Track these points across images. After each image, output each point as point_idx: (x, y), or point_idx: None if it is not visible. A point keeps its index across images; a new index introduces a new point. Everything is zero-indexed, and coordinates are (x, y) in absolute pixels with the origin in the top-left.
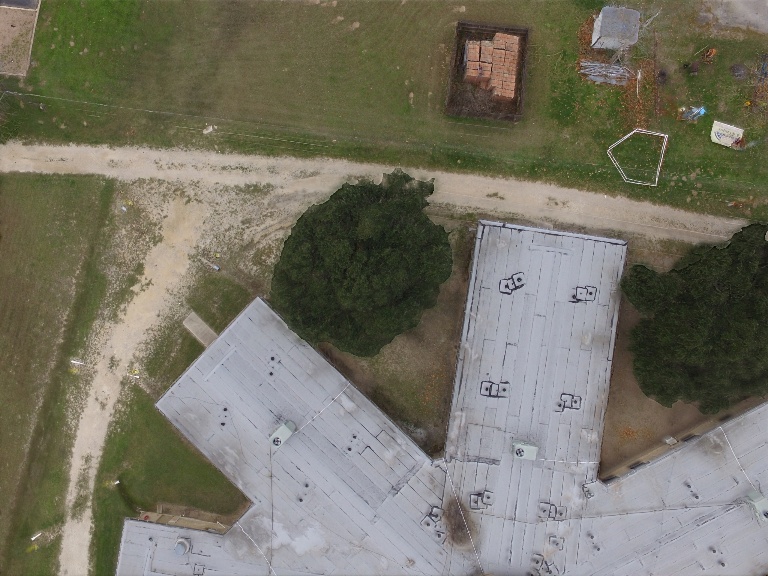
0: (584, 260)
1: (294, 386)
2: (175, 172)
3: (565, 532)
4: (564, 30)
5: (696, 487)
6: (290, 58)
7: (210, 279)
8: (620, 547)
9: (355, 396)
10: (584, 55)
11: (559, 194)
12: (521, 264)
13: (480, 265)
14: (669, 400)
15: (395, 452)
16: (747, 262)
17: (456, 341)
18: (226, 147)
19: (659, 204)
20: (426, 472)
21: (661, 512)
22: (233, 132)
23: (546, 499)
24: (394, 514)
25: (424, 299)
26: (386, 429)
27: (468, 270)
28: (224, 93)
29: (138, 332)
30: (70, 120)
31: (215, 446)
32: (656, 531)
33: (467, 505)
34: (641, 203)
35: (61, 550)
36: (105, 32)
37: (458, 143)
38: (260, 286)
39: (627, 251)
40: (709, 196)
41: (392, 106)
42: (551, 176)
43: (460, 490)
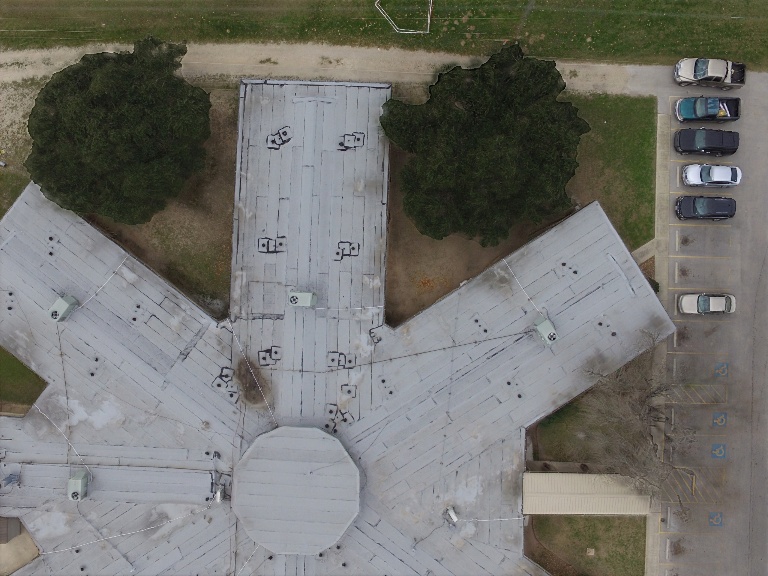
0: (349, 107)
1: (75, 264)
2: None
3: (356, 379)
4: None
5: (484, 321)
6: None
7: None
8: (413, 388)
9: (136, 267)
10: None
11: (332, 52)
12: (286, 118)
13: (246, 124)
14: (436, 231)
15: (180, 318)
16: (483, 74)
17: None
18: (0, 45)
19: (434, 51)
20: (212, 334)
21: (451, 350)
22: (5, 29)
23: (334, 348)
24: None
25: (181, 157)
26: (169, 296)
27: None
28: None
29: None
30: None
31: (5, 331)
32: (447, 369)
33: (256, 362)
34: (416, 52)
35: None
36: None
37: (226, 13)
38: None
39: (392, 94)
40: (484, 37)
41: None
42: (322, 35)
43: (247, 348)
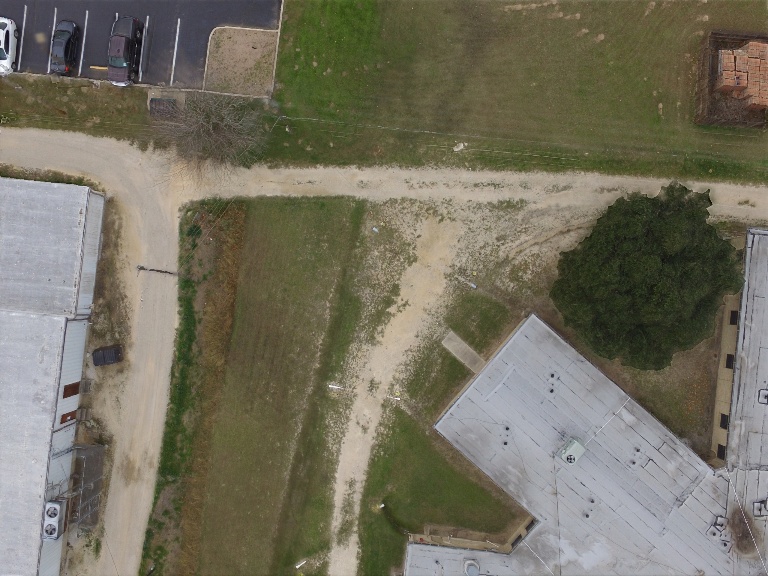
0: None
1: (574, 402)
2: (426, 191)
3: None
4: None
5: None
6: (537, 72)
7: (467, 297)
8: None
9: (635, 410)
10: None
11: None
12: None
13: (752, 274)
14: None
15: (677, 464)
16: None
17: (715, 350)
18: (477, 164)
19: None
20: (709, 482)
21: None
22: (484, 149)
23: None
24: (681, 525)
25: (714, 311)
26: (668, 441)
27: None
28: (472, 109)
29: (397, 354)
30: (316, 142)
31: (498, 466)
32: None
33: (750, 513)
34: None
35: None
36: (347, 51)
37: (709, 152)
38: (518, 303)
39: None
40: None
41: (642, 118)
42: None
43: (743, 498)
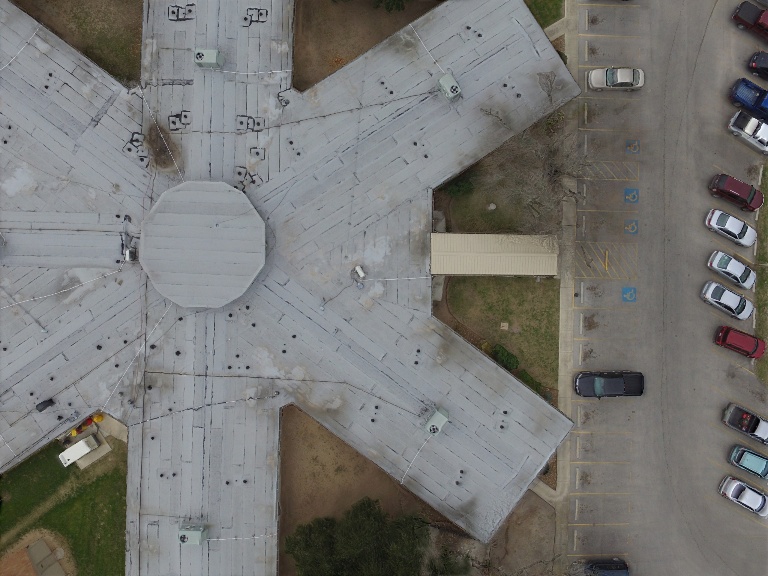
0: None
1: None
2: None
3: (265, 142)
4: None
5: (391, 84)
6: None
7: None
8: (320, 150)
9: (48, 37)
10: None
11: None
12: None
13: None
14: None
15: (92, 85)
16: None
17: None
18: None
19: None
20: (123, 101)
21: (358, 112)
22: None
23: (243, 112)
24: (95, 143)
25: None
26: (81, 64)
27: None
28: None
29: None
30: None
31: None
32: (354, 130)
33: (167, 128)
34: None
35: None
36: None
37: None
38: None
39: None
40: None
41: None
42: None
43: (158, 113)
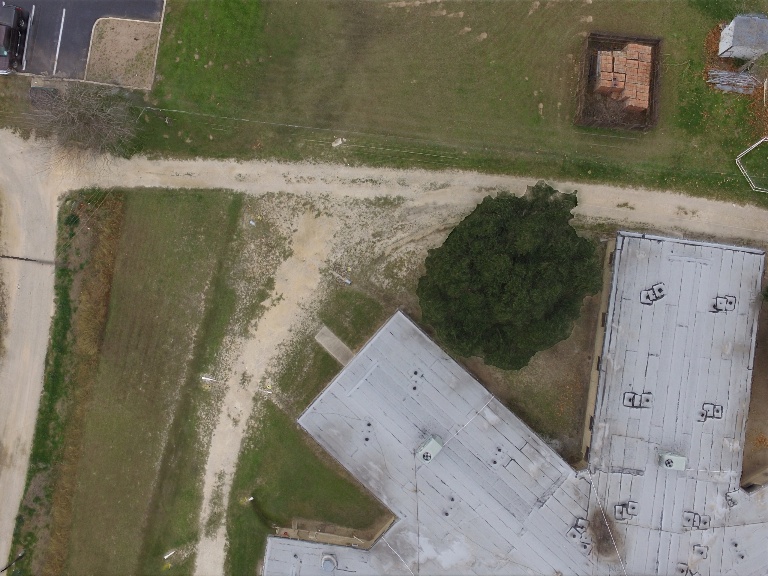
0: (723, 270)
1: (437, 400)
2: (304, 186)
3: (709, 541)
4: (690, 39)
5: None
6: (418, 70)
7: (342, 293)
8: (763, 554)
9: (498, 409)
10: (711, 64)
11: (688, 203)
12: (661, 275)
13: (621, 276)
14: None
15: (539, 464)
16: None
17: (589, 352)
18: (355, 160)
19: None
20: (571, 484)
21: None
22: (363, 145)
23: (690, 508)
24: (540, 526)
25: (573, 312)
26: (530, 441)
27: None
28: (352, 105)
29: (270, 347)
30: (196, 134)
31: (359, 461)
32: None
33: (612, 516)
34: None
35: (195, 568)
36: (229, 44)
37: (588, 154)
38: (392, 299)
39: None
40: None
41: (522, 117)
42: (680, 186)
43: (605, 501)
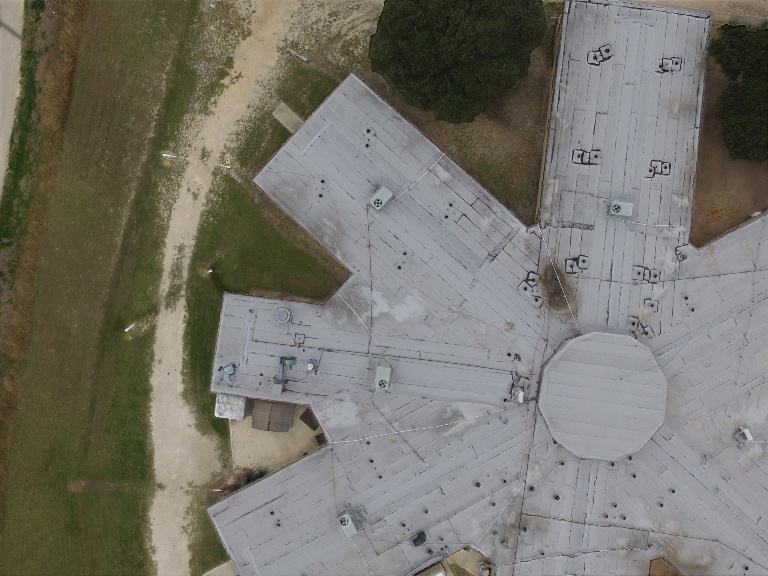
0: (668, 32)
1: (390, 158)
2: None
3: (659, 294)
4: None
5: None
6: None
7: (299, 70)
8: (714, 308)
9: (450, 166)
10: None
11: None
12: (608, 37)
13: (568, 38)
14: (760, 154)
15: (490, 220)
16: None
17: (542, 125)
18: None
19: None
20: (521, 238)
21: (752, 274)
22: None
23: (640, 262)
24: (492, 278)
25: (519, 59)
26: (481, 197)
27: (553, 52)
28: None
29: (229, 123)
30: None
31: (313, 218)
32: (748, 292)
33: (563, 270)
34: None
35: (155, 339)
36: None
37: None
38: None
39: (709, 24)
40: None
41: None
42: None
43: (555, 255)
